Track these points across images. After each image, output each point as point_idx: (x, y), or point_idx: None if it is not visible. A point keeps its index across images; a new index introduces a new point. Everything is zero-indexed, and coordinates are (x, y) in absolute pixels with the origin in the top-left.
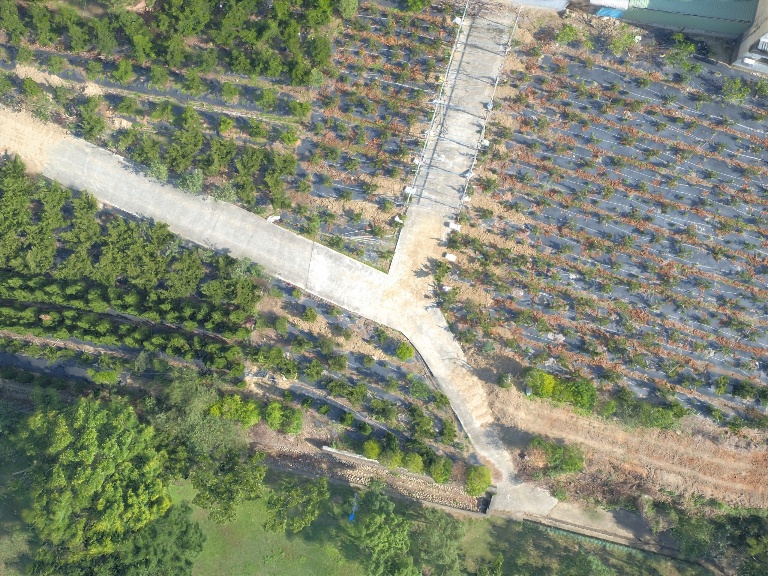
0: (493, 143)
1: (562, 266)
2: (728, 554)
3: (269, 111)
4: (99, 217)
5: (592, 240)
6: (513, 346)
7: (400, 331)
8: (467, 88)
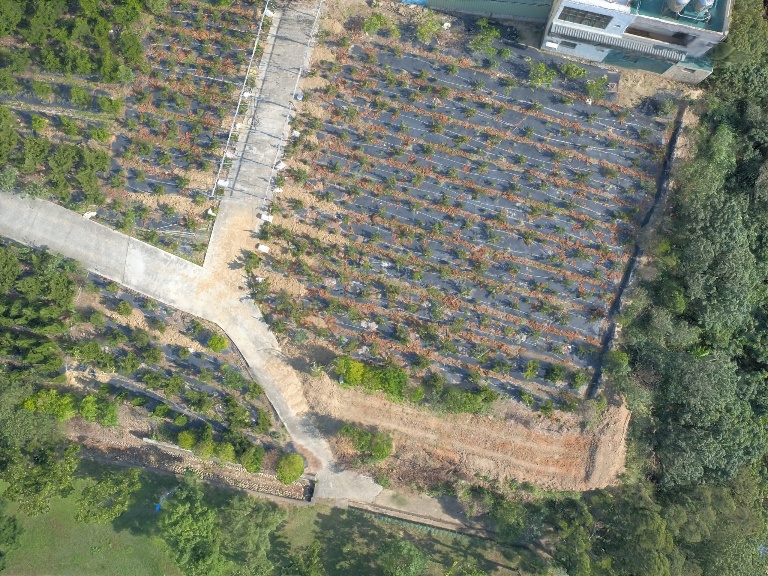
0: (304, 134)
1: (375, 255)
2: (555, 537)
3: (84, 108)
4: None
5: (404, 228)
6: (325, 335)
7: (216, 323)
8: (278, 80)
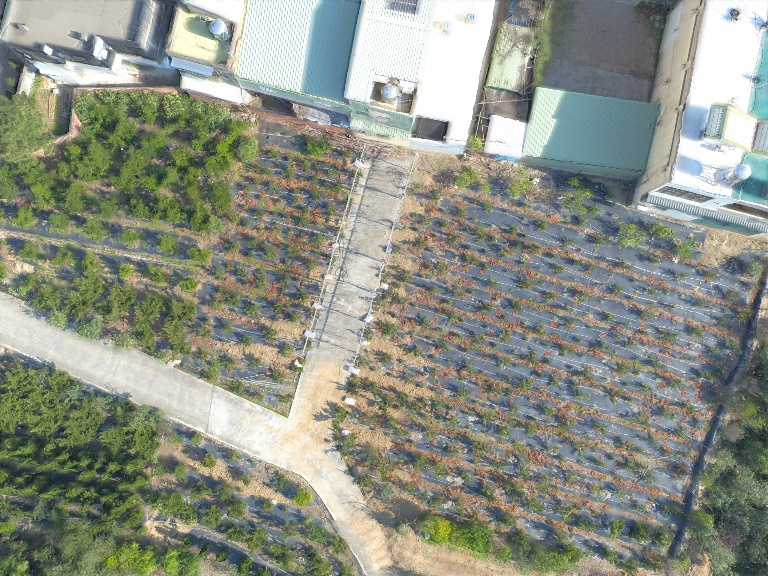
0: (392, 286)
1: (461, 408)
2: None
3: (170, 255)
4: (1, 361)
5: (490, 383)
6: (411, 490)
7: (300, 475)
8: (366, 231)
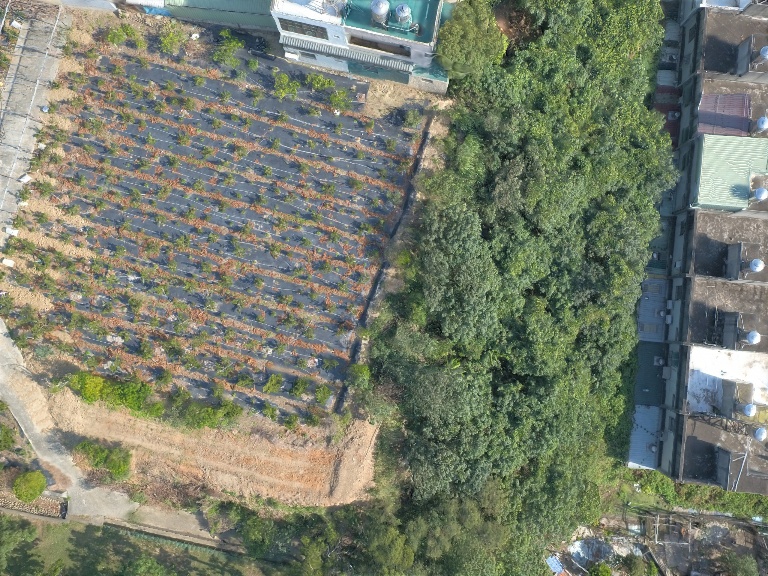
0: (50, 146)
1: (121, 268)
2: None
3: None
4: None
5: (150, 241)
6: (68, 350)
7: None
8: (24, 92)
